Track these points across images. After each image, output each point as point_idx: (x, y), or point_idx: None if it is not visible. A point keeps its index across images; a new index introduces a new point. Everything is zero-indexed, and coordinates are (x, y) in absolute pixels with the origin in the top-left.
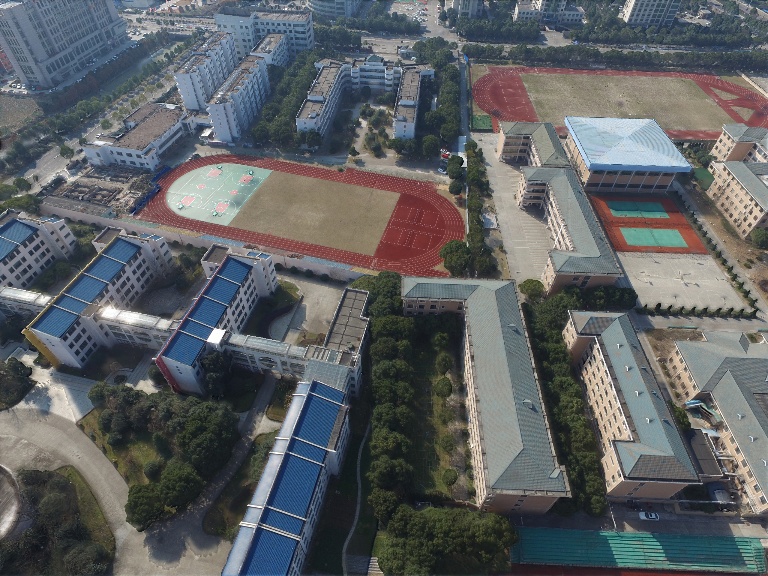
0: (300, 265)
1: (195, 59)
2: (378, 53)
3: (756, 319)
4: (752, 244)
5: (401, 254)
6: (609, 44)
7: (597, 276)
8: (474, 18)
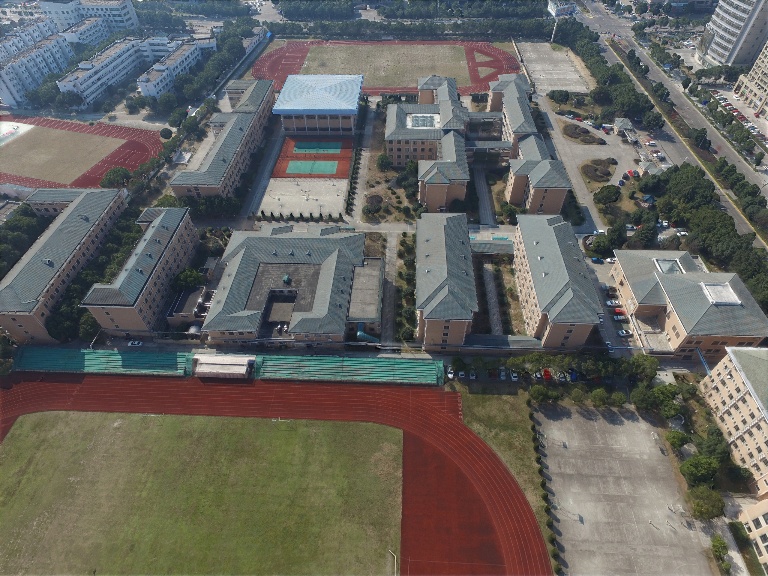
0: None
1: (5, 39)
2: (199, 33)
3: (342, 222)
4: (377, 168)
5: (92, 183)
6: (415, 19)
7: (200, 187)
8: None
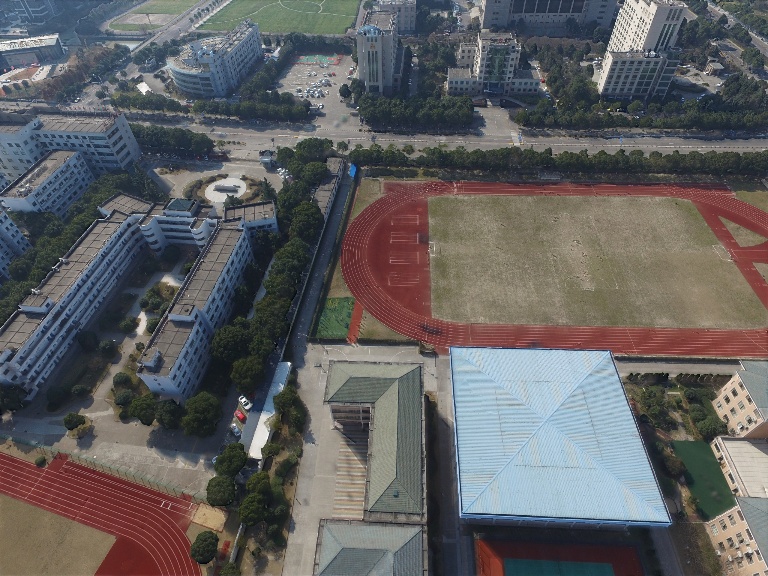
0: None
1: None
2: (235, 160)
3: None
4: None
5: None
6: (573, 129)
7: None
8: (390, 90)
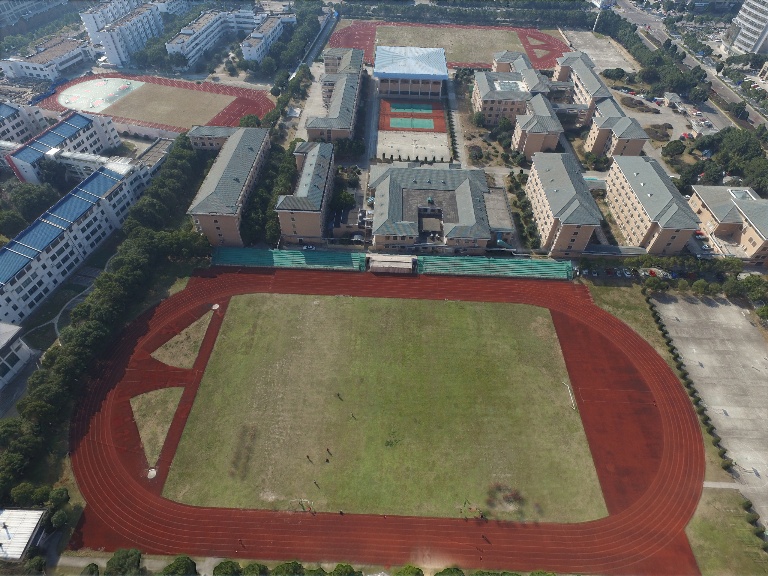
0: (139, 131)
1: (101, 5)
2: (268, 11)
3: None
4: None
5: None
6: (465, 7)
7: (333, 130)
8: None
